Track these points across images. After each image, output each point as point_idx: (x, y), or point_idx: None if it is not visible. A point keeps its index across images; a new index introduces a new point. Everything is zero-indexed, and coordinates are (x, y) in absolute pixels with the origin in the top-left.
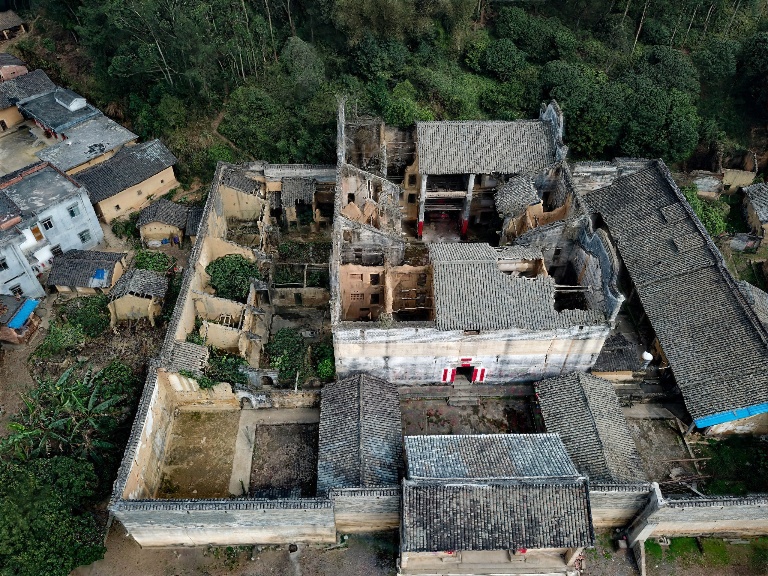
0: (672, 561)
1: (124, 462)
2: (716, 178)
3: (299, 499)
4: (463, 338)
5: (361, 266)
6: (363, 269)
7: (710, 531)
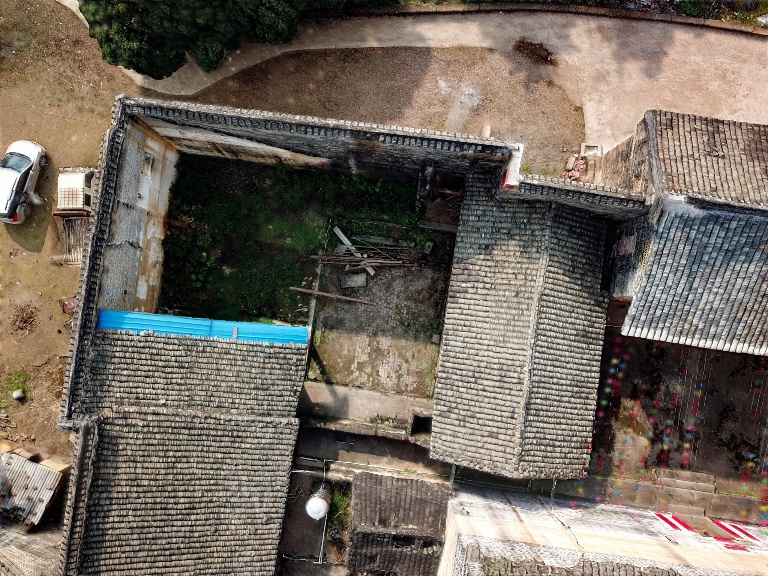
0: None
1: None
2: None
3: None
4: None
5: None
6: None
7: None
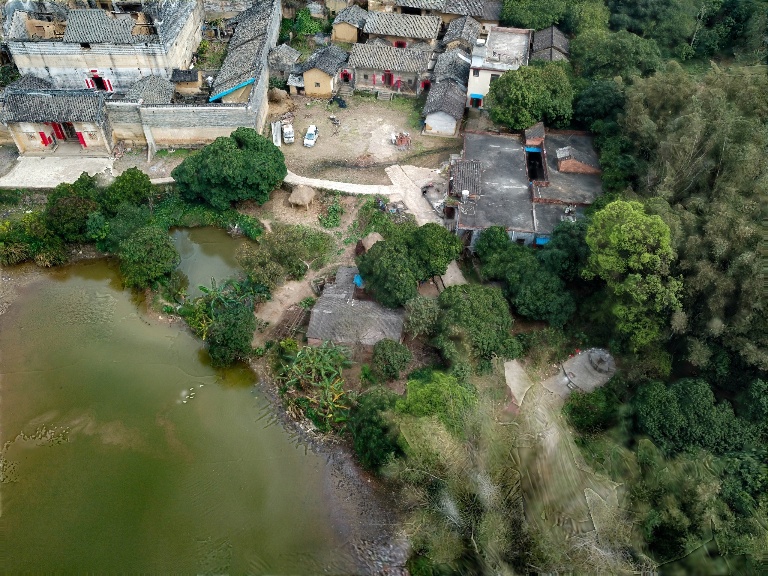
0: (170, 157)
1: None
2: (318, 3)
3: None
4: (83, 52)
5: (40, 20)
6: (42, 22)
7: (192, 142)
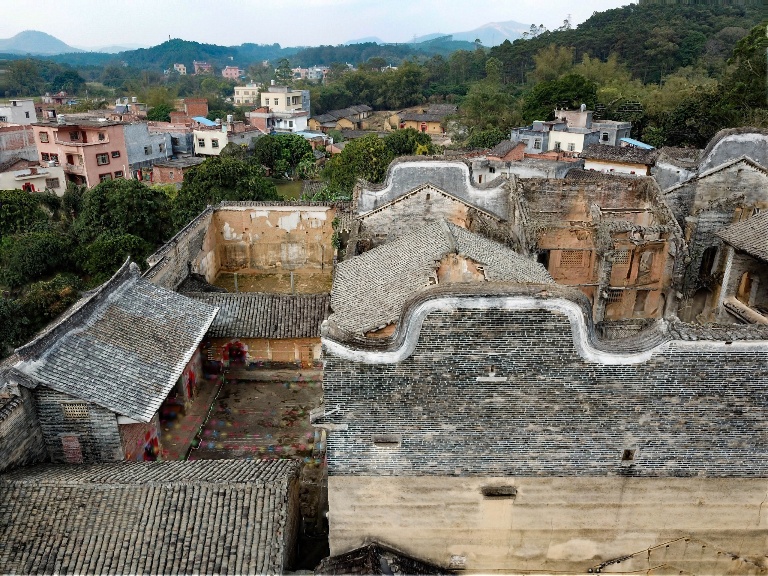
0: None
1: (241, 201)
2: None
3: (166, 248)
4: None
5: None
6: None
7: None
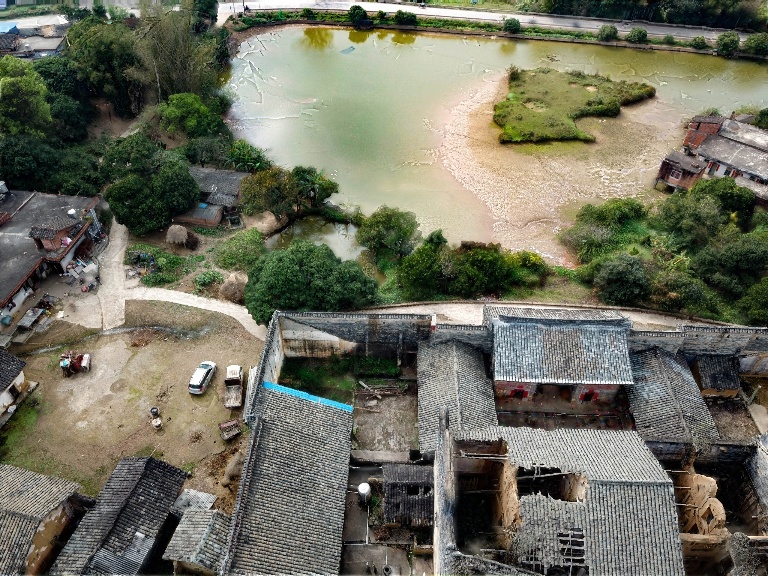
0: None
1: None
2: None
3: (706, 329)
4: None
5: None
6: (765, 537)
7: None
